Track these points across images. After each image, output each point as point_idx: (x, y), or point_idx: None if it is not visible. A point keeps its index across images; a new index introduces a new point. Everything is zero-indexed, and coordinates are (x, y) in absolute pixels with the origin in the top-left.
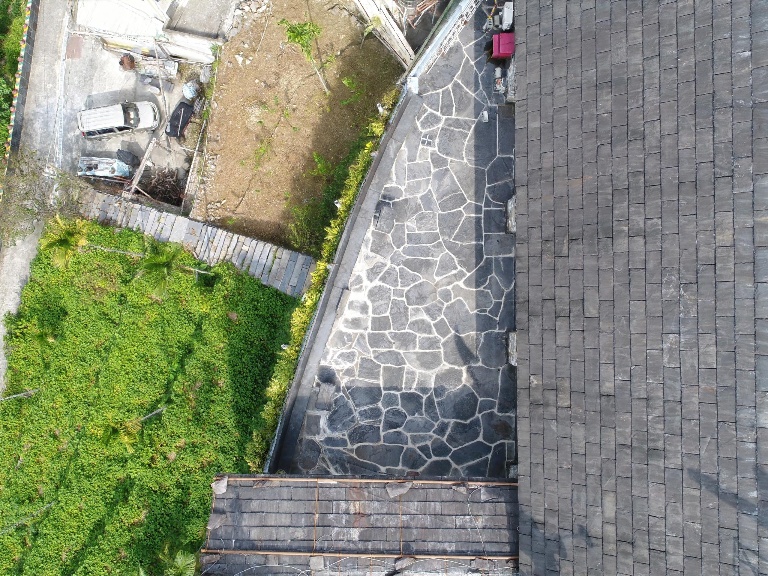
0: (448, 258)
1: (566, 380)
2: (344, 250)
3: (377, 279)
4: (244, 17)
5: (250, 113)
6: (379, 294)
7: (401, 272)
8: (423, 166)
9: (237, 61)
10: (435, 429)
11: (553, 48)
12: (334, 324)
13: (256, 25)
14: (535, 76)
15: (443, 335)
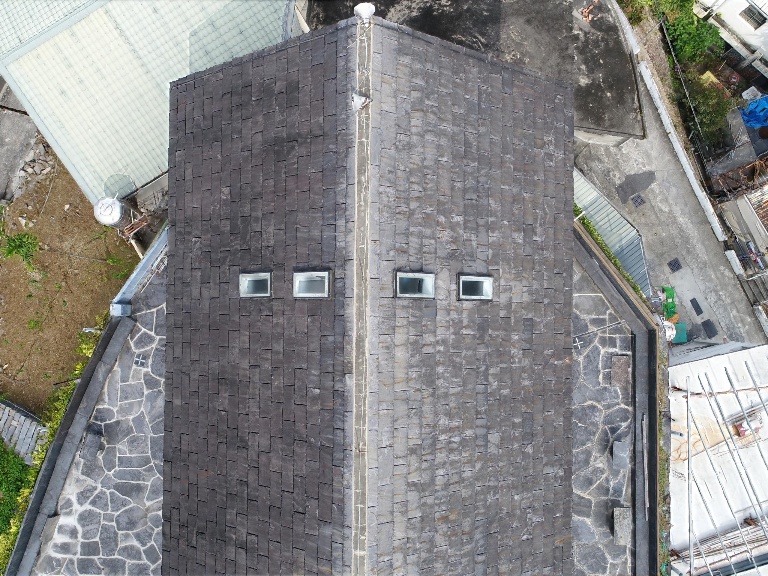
0: (159, 482)
1: None
2: (50, 476)
3: (87, 503)
4: (28, 179)
5: (31, 278)
6: (89, 518)
7: (111, 496)
8: (136, 387)
9: (21, 223)
10: None
11: (191, 328)
12: (43, 548)
13: (41, 186)
14: (179, 351)
15: (153, 562)
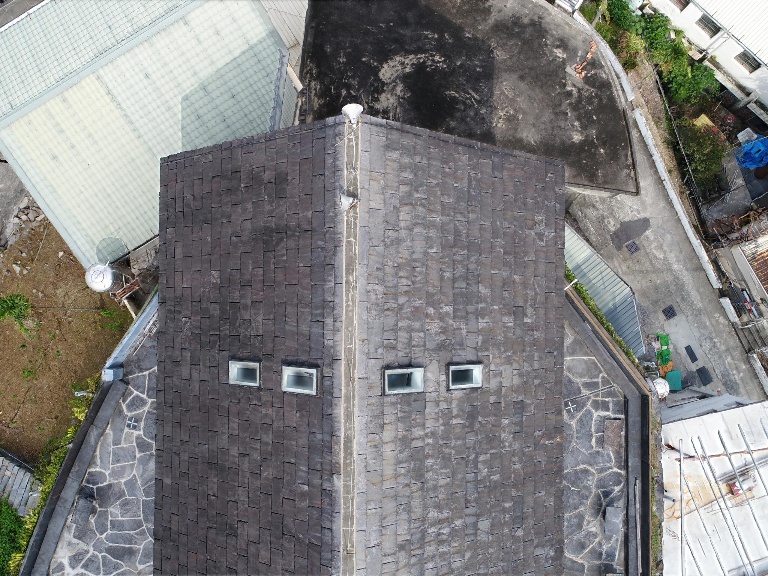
0: (151, 546)
1: None
2: (41, 540)
3: (79, 566)
4: (22, 226)
5: None
6: None
7: (103, 560)
8: (128, 450)
9: (15, 270)
10: None
11: (181, 408)
12: None
13: (35, 233)
14: (169, 430)
15: None
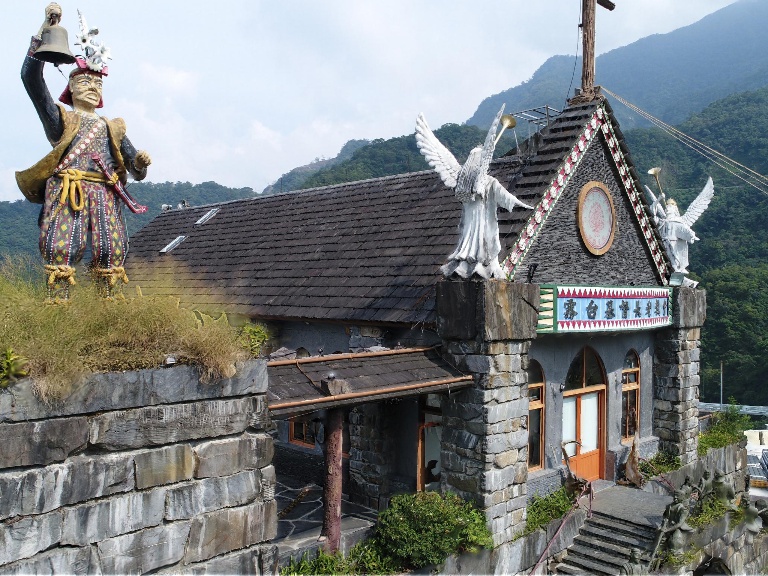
0: None
1: (290, 280)
2: None
3: None
4: None
5: None
6: None
7: None
8: None
9: None
10: None
11: None
12: None
13: None
14: None
15: None
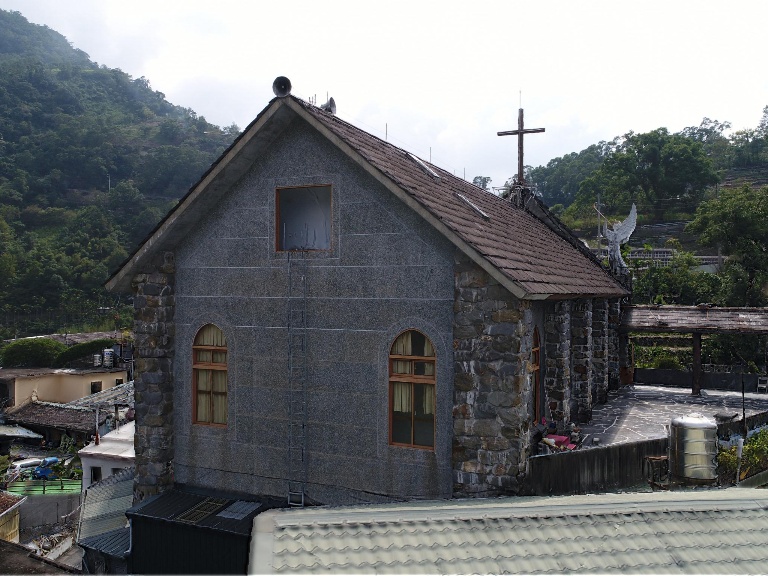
0: None
1: None
2: None
3: None
4: None
5: None
6: None
7: None
8: None
9: None
10: (676, 398)
11: None
12: None
13: None
14: None
15: None
